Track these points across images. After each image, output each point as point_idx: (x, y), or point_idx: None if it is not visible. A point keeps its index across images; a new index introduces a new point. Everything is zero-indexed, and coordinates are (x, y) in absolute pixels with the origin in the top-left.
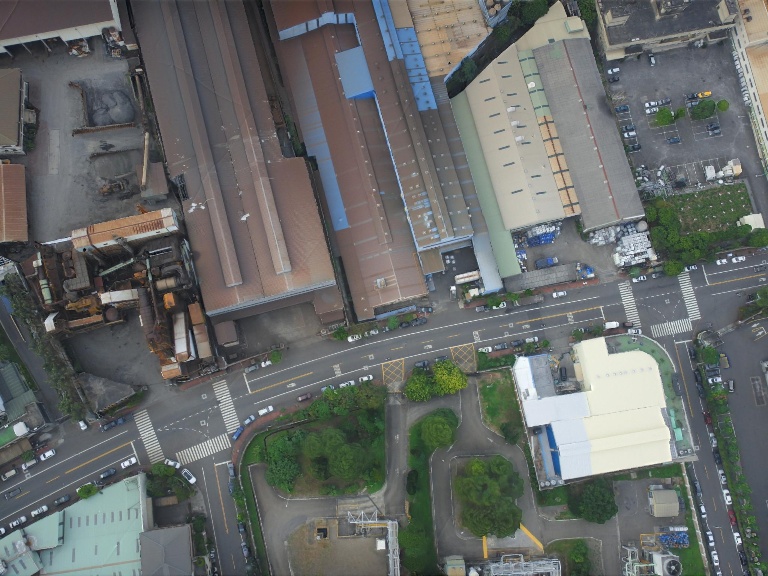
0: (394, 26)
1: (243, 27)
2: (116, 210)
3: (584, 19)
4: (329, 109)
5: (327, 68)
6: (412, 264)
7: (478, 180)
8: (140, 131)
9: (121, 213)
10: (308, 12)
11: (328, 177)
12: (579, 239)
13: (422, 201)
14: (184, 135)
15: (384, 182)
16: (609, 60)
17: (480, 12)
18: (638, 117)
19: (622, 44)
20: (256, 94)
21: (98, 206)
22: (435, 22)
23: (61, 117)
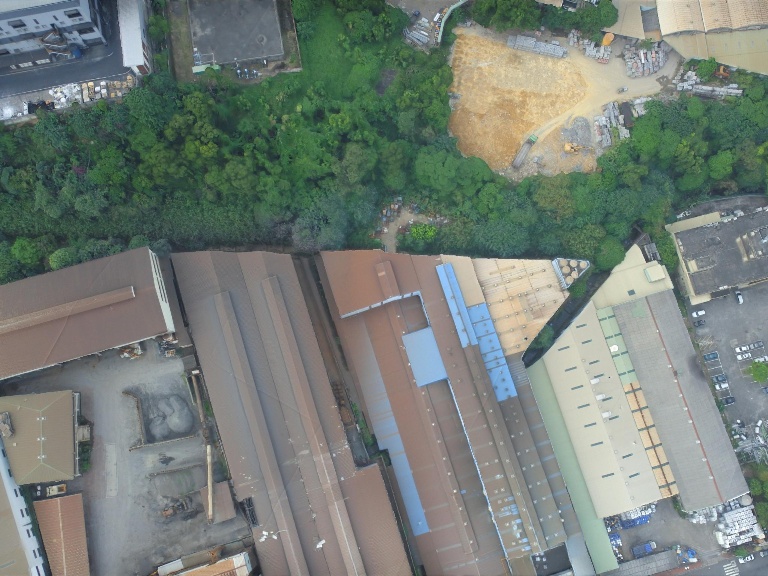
0: (465, 306)
1: (305, 324)
2: (180, 532)
3: (664, 264)
4: (399, 396)
5: (394, 350)
6: (501, 572)
7: (564, 461)
8: (200, 439)
9: (186, 535)
10: (371, 295)
11: (403, 474)
12: (677, 516)
13: (509, 508)
14: (249, 453)
15: (464, 478)
16: (694, 304)
17: (554, 274)
18: (729, 364)
19: (709, 292)
20: (323, 400)
21: (161, 529)
22: (507, 291)
23: (116, 430)
